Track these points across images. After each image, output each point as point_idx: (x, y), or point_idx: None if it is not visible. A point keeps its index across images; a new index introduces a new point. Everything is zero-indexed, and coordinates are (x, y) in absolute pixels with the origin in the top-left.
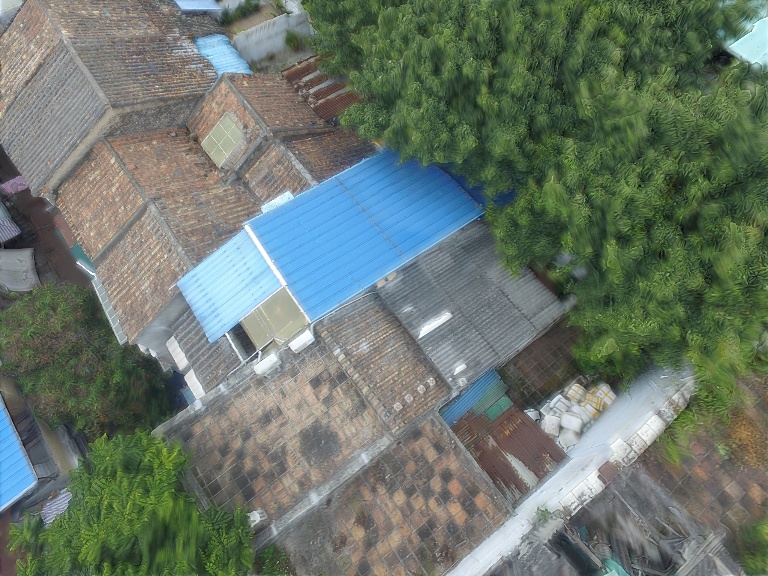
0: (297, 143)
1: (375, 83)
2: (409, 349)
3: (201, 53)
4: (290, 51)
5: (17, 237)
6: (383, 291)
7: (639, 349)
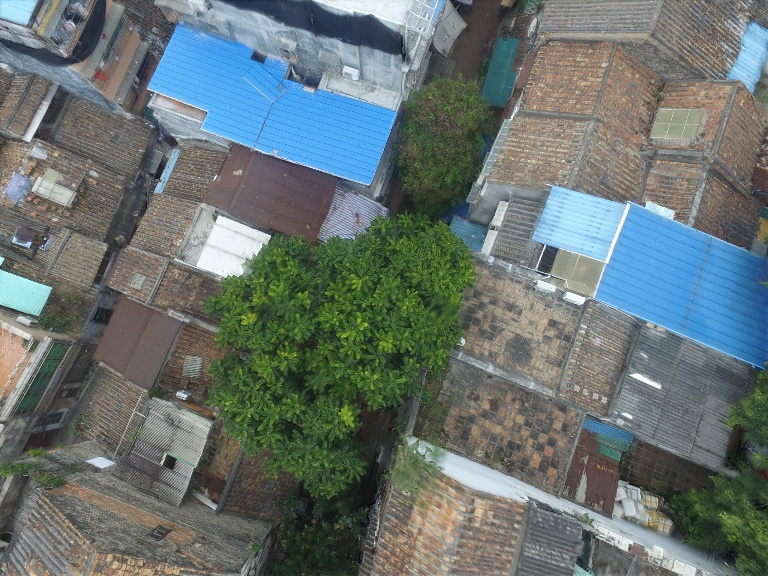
0: (716, 180)
1: None
2: (614, 371)
3: (742, 38)
4: None
5: (466, 5)
6: (646, 330)
7: (735, 539)
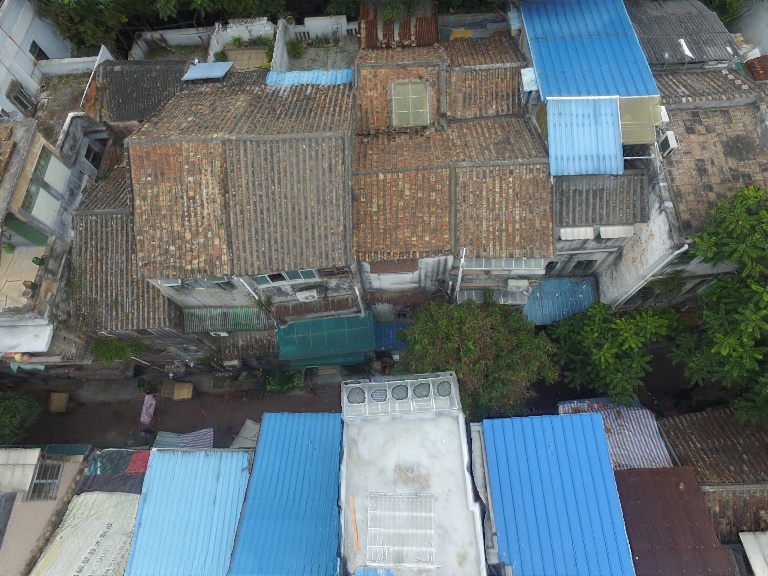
0: (451, 64)
1: None
2: None
3: None
4: (296, 62)
5: (214, 435)
6: None
7: None
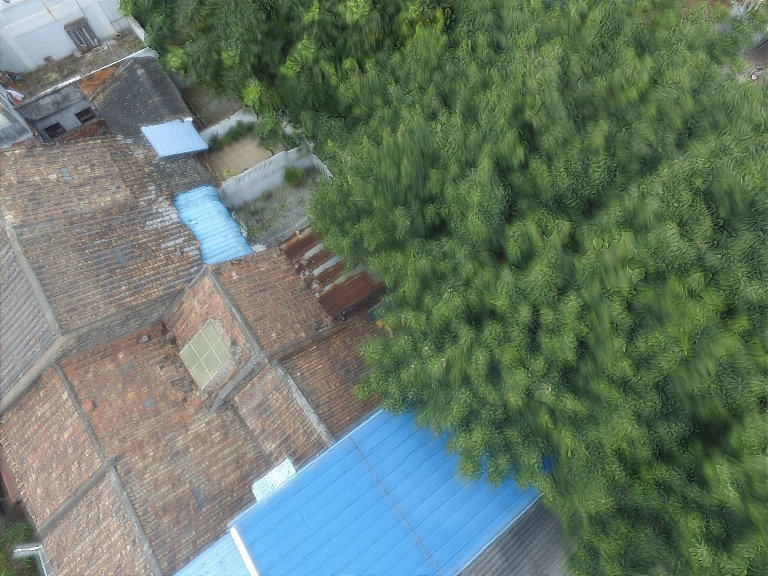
0: (299, 357)
1: (406, 378)
2: None
3: (182, 218)
4: (290, 187)
5: None
6: None
7: None
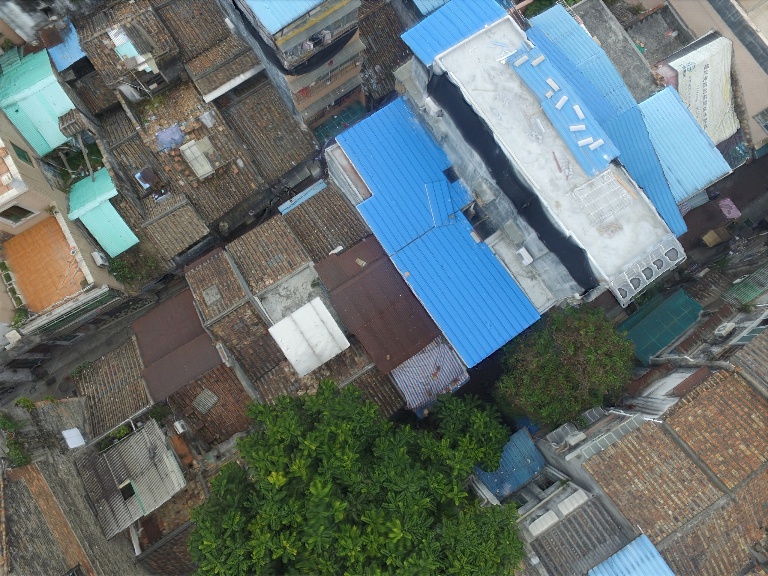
0: None
1: None
2: None
3: None
4: None
5: None
6: None
7: None
